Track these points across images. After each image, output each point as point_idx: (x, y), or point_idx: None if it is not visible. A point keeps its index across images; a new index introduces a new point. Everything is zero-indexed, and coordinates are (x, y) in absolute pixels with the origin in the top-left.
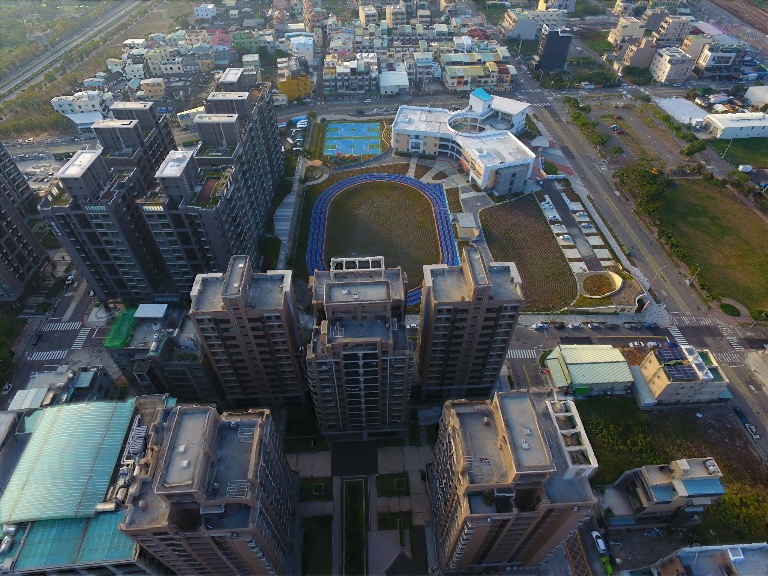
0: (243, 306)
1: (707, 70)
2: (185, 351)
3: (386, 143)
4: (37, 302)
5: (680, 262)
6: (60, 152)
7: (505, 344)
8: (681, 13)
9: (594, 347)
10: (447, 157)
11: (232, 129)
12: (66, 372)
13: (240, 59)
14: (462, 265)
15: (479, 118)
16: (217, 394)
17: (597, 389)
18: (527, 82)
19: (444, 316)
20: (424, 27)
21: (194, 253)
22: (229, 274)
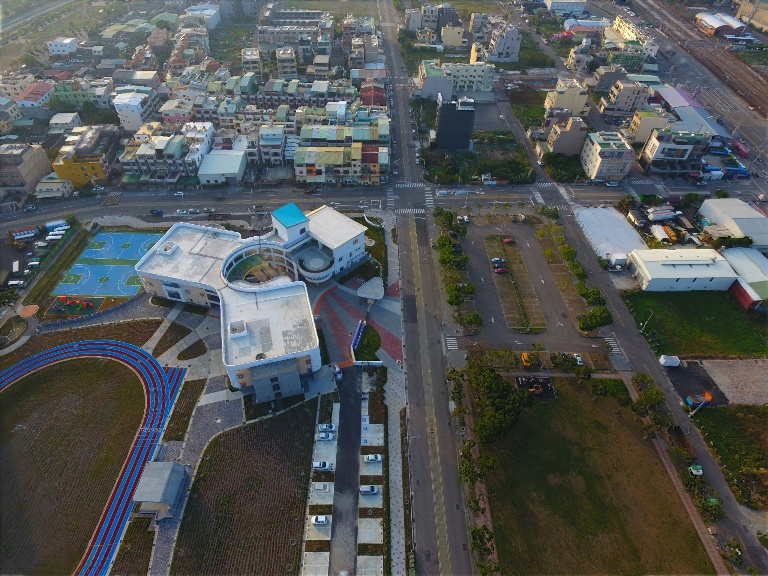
0: None
1: (655, 164)
2: None
3: None
4: None
5: None
6: None
7: None
8: (647, 70)
9: None
10: None
11: None
12: None
13: (49, 119)
14: None
15: (282, 250)
16: None
17: None
18: (410, 170)
19: None
20: (299, 84)
21: None
22: None
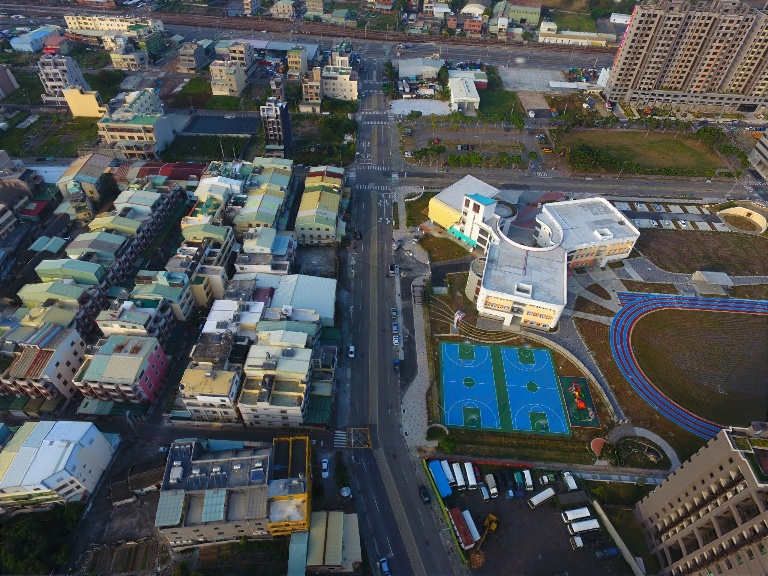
0: None
1: None
2: None
3: (515, 339)
4: None
5: (683, 178)
6: None
7: None
8: (179, 41)
9: None
10: None
11: None
12: None
13: None
14: None
15: None
16: None
17: None
18: None
19: None
20: None
21: None
22: None
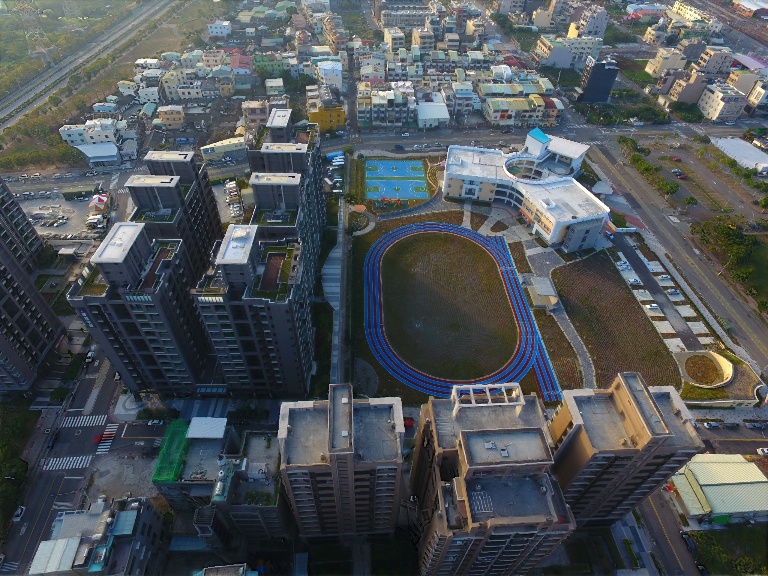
0: (352, 460)
1: (759, 108)
2: (254, 486)
3: (433, 185)
4: (52, 387)
5: None
6: (71, 191)
7: (656, 484)
8: (715, 43)
9: (722, 458)
10: (503, 204)
11: (294, 191)
12: (102, 513)
13: (263, 84)
14: (613, 392)
15: (536, 161)
16: (287, 530)
17: (736, 516)
18: None
19: (598, 463)
20: (458, 53)
21: (252, 345)
22: (332, 415)
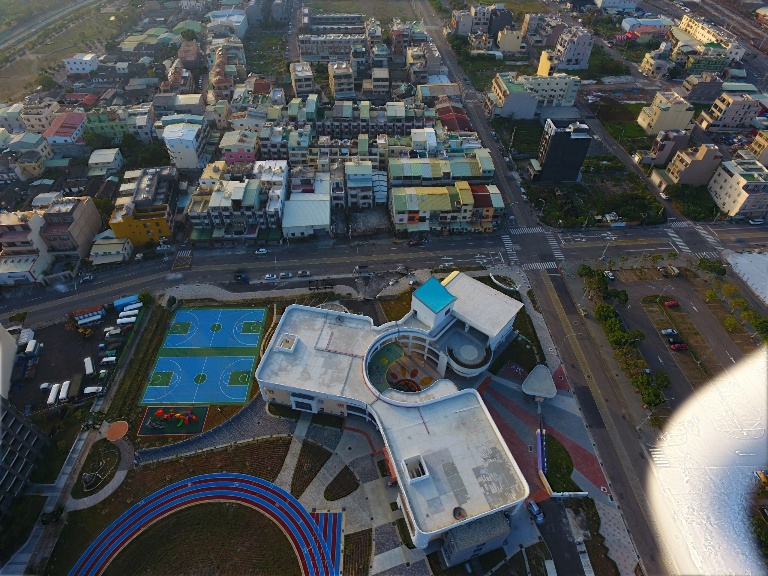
0: None
1: None
2: None
3: None
4: None
5: None
6: None
7: None
8: (734, 76)
9: None
10: (364, 421)
11: None
12: None
13: (87, 158)
14: None
15: (428, 339)
16: None
17: None
18: (520, 210)
19: None
20: (371, 107)
21: None
22: None
